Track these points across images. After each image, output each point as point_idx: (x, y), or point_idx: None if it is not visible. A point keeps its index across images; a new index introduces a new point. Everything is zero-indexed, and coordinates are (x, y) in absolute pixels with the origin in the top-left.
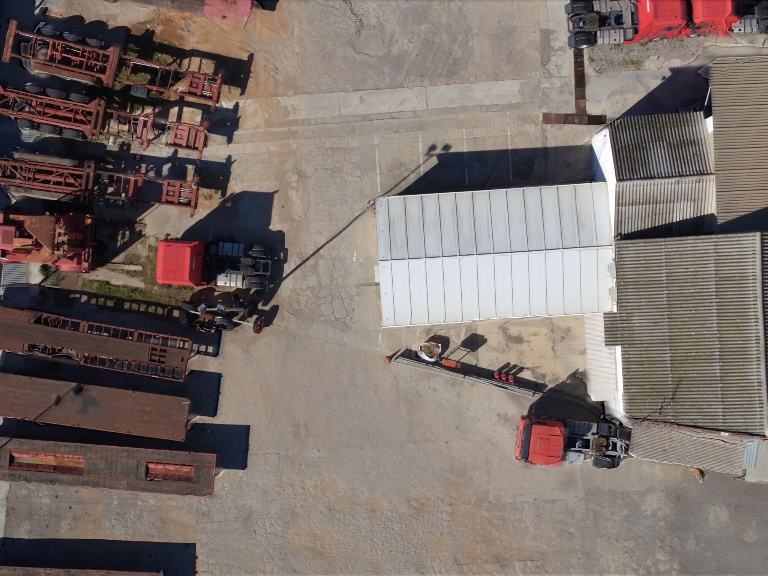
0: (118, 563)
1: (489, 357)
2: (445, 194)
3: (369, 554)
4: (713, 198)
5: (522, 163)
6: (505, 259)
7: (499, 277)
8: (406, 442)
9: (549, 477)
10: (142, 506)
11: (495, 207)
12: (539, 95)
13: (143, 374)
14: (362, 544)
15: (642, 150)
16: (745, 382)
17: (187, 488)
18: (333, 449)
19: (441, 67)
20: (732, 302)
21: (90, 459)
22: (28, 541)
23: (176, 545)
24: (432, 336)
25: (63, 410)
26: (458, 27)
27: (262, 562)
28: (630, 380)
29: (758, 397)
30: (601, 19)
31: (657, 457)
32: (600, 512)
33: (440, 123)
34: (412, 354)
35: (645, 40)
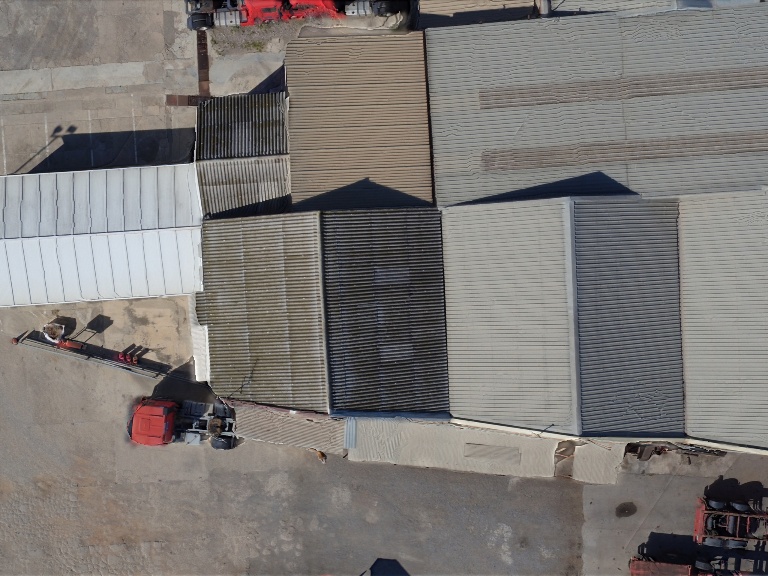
0: None
1: (115, 338)
2: (46, 174)
3: None
4: (288, 177)
5: (146, 145)
6: (102, 239)
7: (97, 257)
8: (33, 424)
9: (174, 458)
10: None
11: (95, 187)
12: (163, 77)
13: None
14: None
15: (226, 130)
16: (310, 360)
17: None
18: None
19: (66, 48)
20: (299, 281)
21: None
22: None
23: None
24: (57, 317)
25: None
26: (83, 9)
27: None
28: (215, 359)
29: (321, 375)
30: (216, 1)
31: (261, 437)
32: (224, 493)
33: (65, 104)
34: (39, 336)
35: (258, 22)
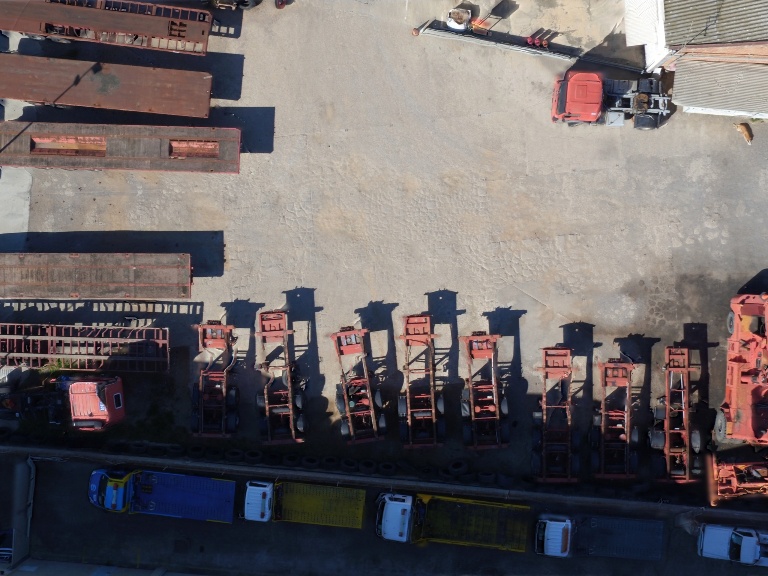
0: (144, 249)
1: (521, 23)
2: None
3: (402, 235)
4: None
5: None
6: None
7: None
8: (437, 117)
9: (588, 146)
10: (167, 195)
11: None
12: None
13: (163, 50)
14: (394, 225)
15: None
16: None
17: (212, 164)
18: (361, 128)
19: None
20: None
21: (112, 140)
22: (53, 235)
23: (203, 233)
24: (461, 3)
25: (83, 90)
26: None
27: (292, 248)
28: (672, 5)
29: None
30: None
31: (702, 103)
32: (643, 181)
33: None
34: (441, 25)
35: None
